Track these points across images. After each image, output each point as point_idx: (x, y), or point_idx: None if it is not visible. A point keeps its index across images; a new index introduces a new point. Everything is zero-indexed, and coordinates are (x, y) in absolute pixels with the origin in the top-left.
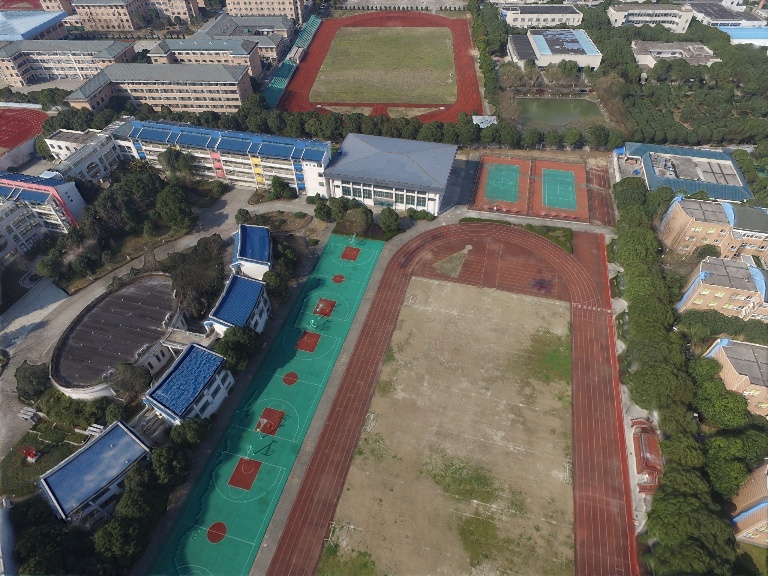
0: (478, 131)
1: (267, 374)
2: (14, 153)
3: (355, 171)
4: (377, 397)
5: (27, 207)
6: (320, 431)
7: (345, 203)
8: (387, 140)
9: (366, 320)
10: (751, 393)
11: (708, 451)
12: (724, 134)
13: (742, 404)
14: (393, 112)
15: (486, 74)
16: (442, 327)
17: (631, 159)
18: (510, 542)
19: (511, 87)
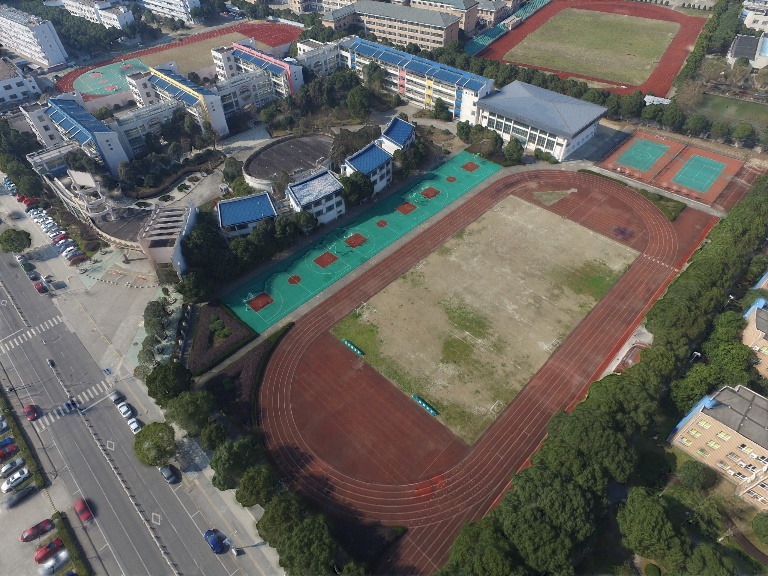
0: (641, 106)
1: (368, 216)
2: (276, 49)
3: (503, 106)
4: (435, 254)
5: (269, 77)
6: (384, 257)
7: (483, 128)
8: (545, 91)
9: (456, 209)
10: (763, 351)
11: (685, 373)
12: None
13: (744, 351)
14: None
15: None
16: (513, 232)
17: None
18: (477, 362)
19: (710, 83)
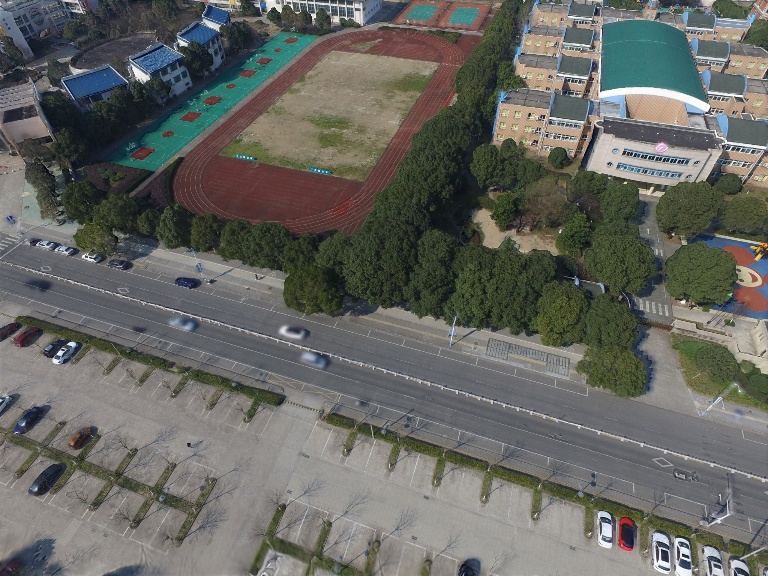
0: None
1: (215, 84)
2: None
3: None
4: (287, 94)
5: None
6: (244, 105)
7: (291, 8)
8: None
9: (291, 66)
10: (528, 77)
11: None
12: None
13: (517, 78)
14: None
15: None
16: (343, 70)
17: None
18: (349, 141)
19: None
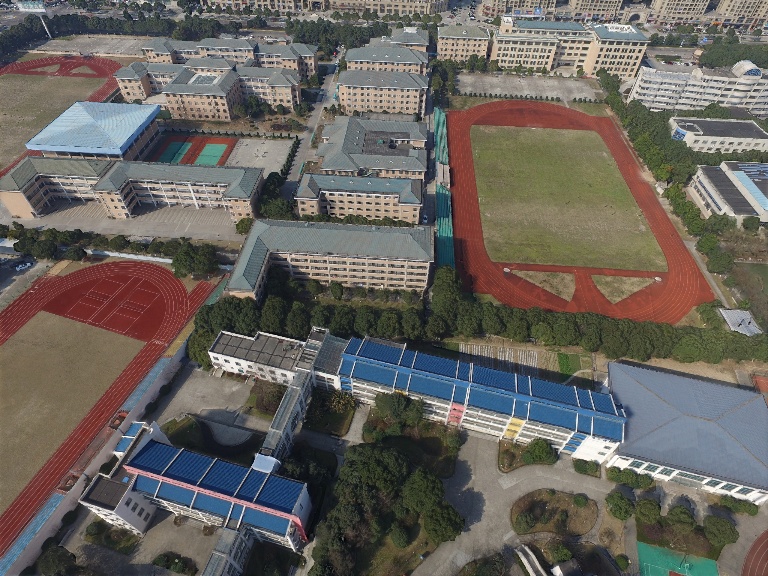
0: None
1: None
2: (168, 369)
3: (662, 452)
4: None
5: (247, 526)
6: None
7: None
8: (669, 382)
9: None
10: None
11: None
12: None
13: None
14: (603, 285)
15: (696, 229)
16: None
17: None
18: None
19: None
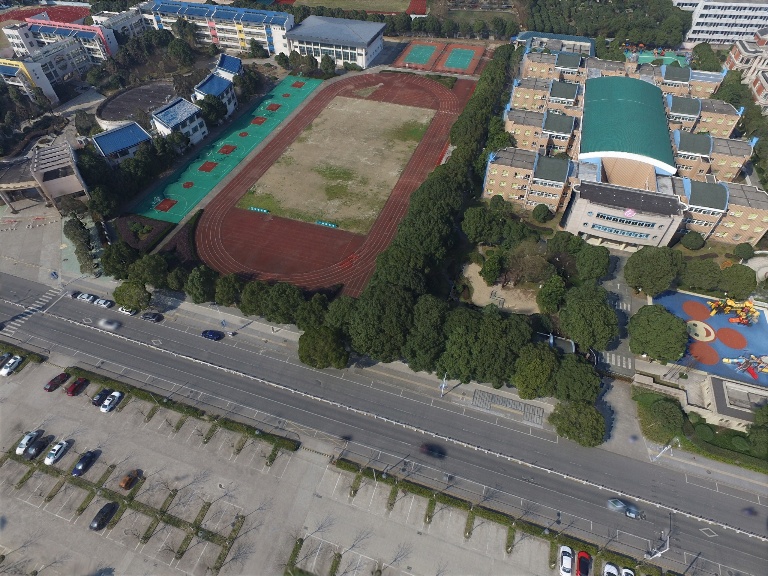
0: (409, 21)
1: (229, 132)
2: None
3: (307, 33)
4: (295, 143)
5: (81, 44)
6: (256, 154)
7: (298, 53)
8: (336, 19)
9: (299, 113)
10: (516, 133)
11: None
12: (596, 29)
13: (506, 135)
14: None
15: None
16: (347, 117)
17: (521, 43)
18: (353, 193)
19: None
